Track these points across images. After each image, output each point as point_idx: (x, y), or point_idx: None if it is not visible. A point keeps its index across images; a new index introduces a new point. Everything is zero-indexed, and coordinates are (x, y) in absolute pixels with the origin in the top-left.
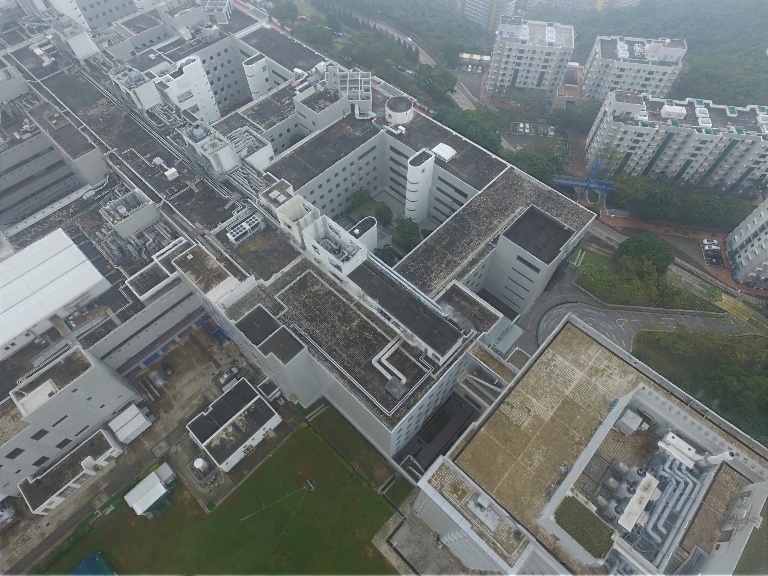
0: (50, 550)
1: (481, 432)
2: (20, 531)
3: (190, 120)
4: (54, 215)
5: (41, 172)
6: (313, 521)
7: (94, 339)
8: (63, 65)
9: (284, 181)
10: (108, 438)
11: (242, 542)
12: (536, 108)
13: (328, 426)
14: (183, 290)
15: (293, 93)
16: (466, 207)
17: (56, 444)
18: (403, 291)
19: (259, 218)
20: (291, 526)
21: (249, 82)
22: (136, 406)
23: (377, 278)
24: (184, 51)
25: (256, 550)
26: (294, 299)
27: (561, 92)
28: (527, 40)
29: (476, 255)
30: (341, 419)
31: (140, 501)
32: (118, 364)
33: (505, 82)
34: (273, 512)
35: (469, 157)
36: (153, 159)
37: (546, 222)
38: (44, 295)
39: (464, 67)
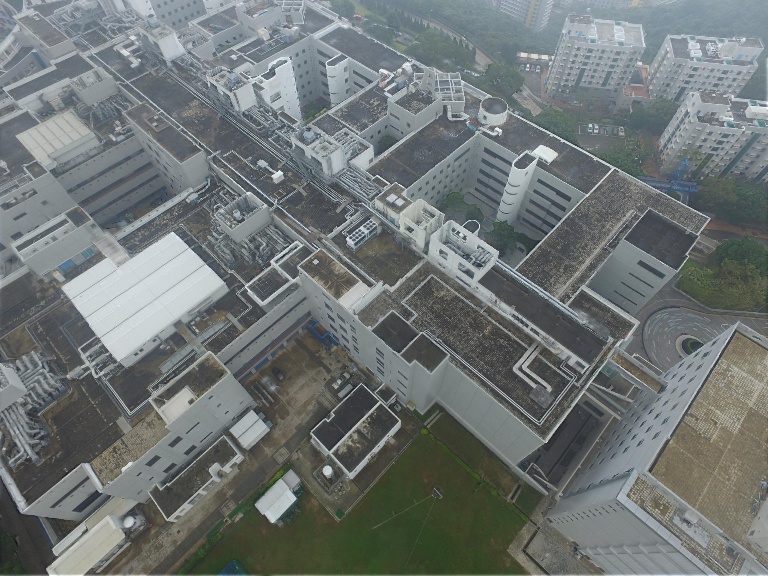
0: (184, 558)
1: (670, 445)
2: (152, 538)
3: (289, 122)
4: (159, 218)
5: (129, 174)
6: (446, 530)
7: (218, 345)
8: (150, 66)
9: (397, 184)
10: (232, 444)
11: (377, 551)
12: (599, 108)
13: (447, 433)
14: (300, 295)
15: (381, 94)
16: (575, 210)
17: (184, 451)
18: (538, 297)
19: (376, 222)
20: (424, 535)
21: (330, 83)
22: (254, 412)
23: (509, 284)
24: (264, 52)
25: (392, 559)
26: (422, 305)
27: (627, 92)
28: (596, 39)
29: (593, 260)
30: (458, 426)
31: (272, 509)
32: (235, 369)
33: (569, 82)
34: (404, 520)
35: (570, 159)
36: (257, 162)
37: (665, 226)
38: (169, 300)
39: (522, 66)
